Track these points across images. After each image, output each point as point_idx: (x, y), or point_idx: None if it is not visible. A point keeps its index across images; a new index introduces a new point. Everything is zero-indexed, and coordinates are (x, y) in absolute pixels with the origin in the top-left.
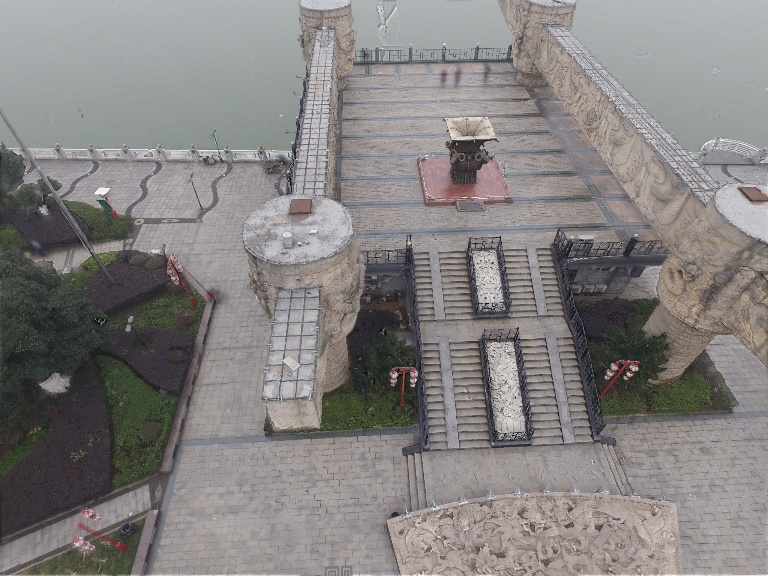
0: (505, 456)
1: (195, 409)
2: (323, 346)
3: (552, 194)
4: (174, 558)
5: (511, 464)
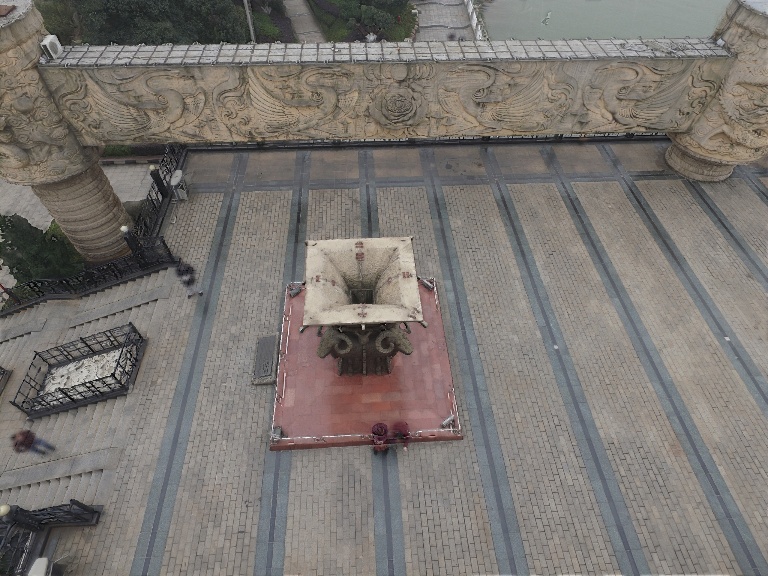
0: None
1: (124, 168)
2: None
3: (292, 569)
4: (1, 180)
5: None
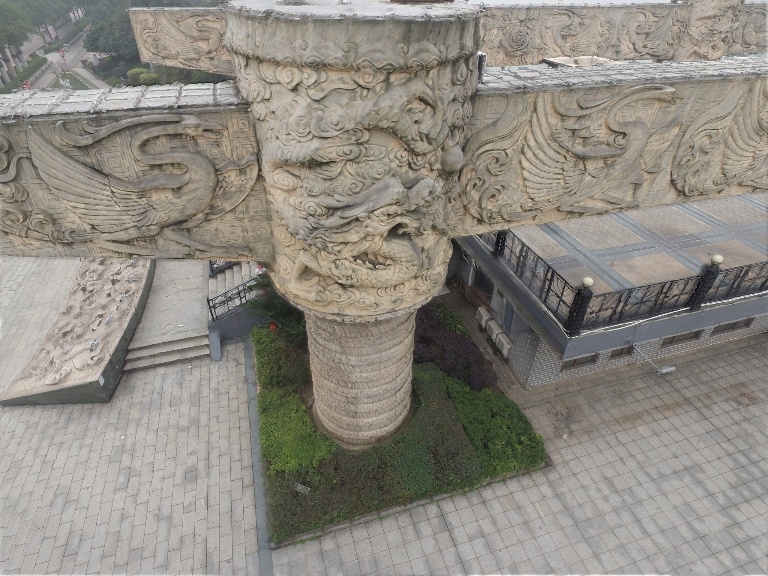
0: (200, 264)
1: None
2: (194, 37)
3: None
4: None
5: (190, 268)
